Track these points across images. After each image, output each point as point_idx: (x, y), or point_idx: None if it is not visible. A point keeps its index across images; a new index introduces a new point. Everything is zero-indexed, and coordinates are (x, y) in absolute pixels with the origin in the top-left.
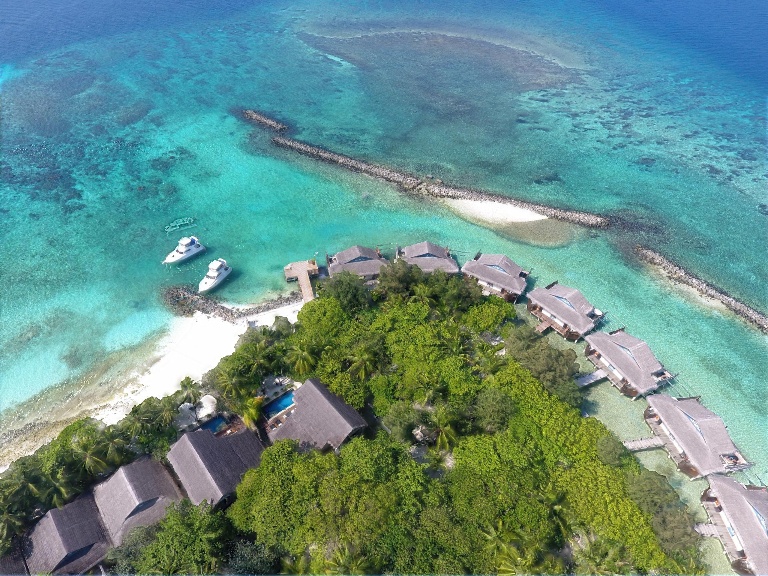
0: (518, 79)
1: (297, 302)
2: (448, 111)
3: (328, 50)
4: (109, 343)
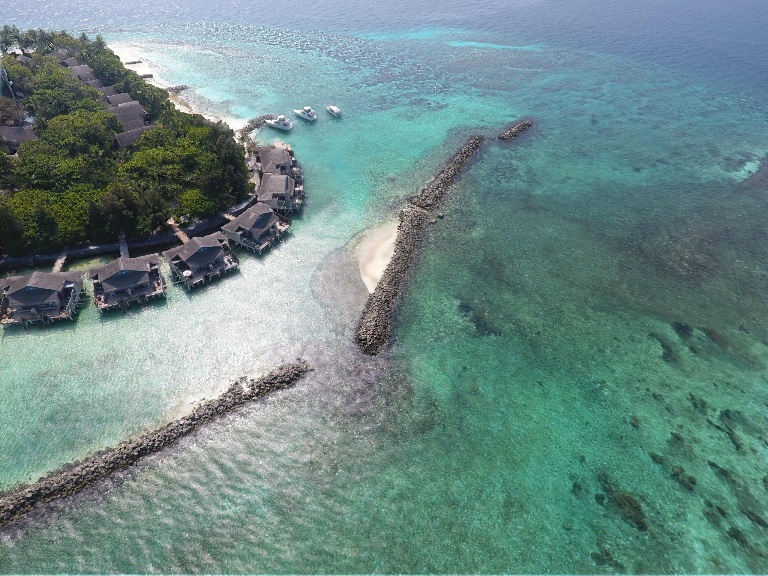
0: None
1: None
2: (650, 249)
3: None
4: (234, 107)
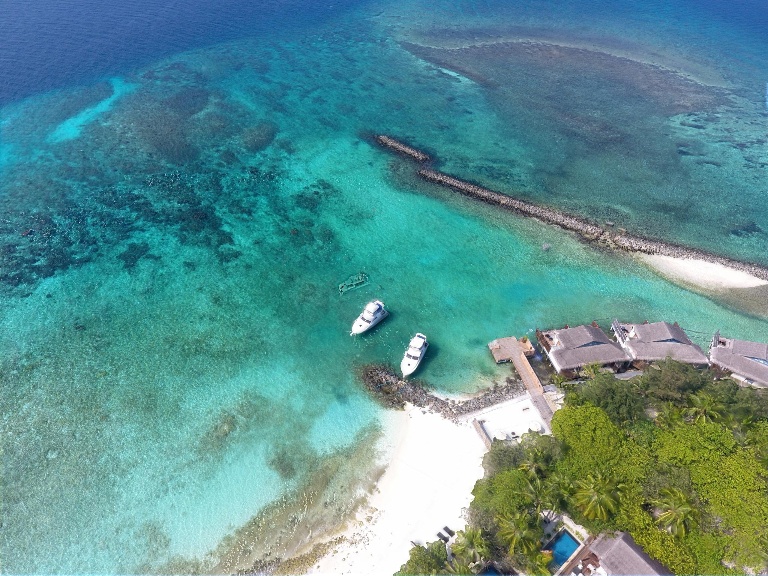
0: (659, 99)
1: (521, 395)
2: (597, 139)
3: (440, 63)
4: (318, 443)
